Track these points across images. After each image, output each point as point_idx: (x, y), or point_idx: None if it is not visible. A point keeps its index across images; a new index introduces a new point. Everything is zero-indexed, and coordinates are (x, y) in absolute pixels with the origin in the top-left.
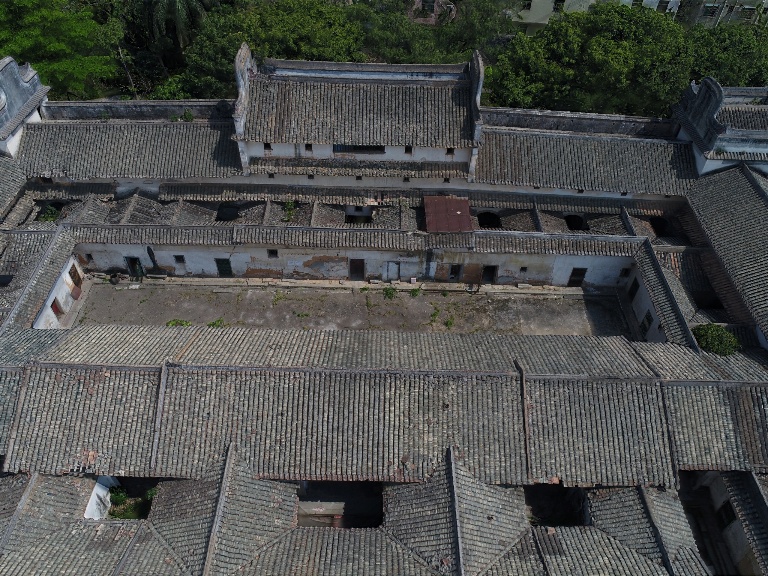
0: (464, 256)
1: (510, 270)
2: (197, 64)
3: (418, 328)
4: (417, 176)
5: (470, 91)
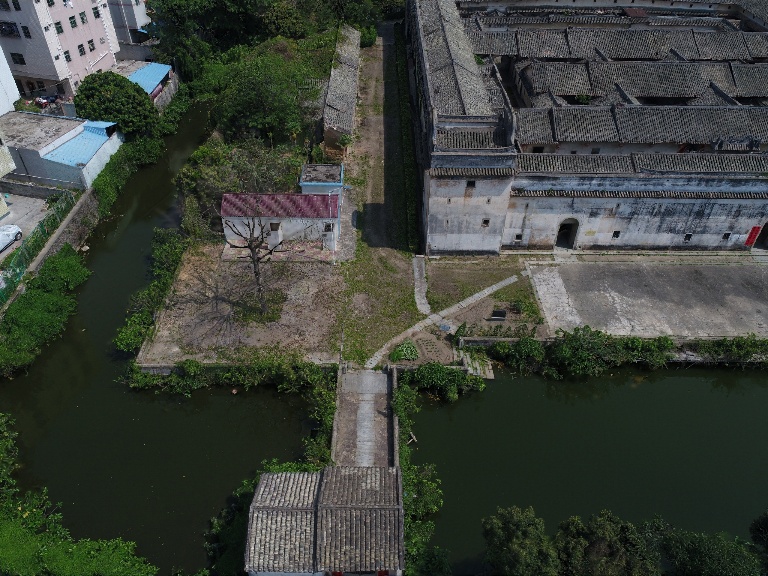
0: None
1: None
2: None
3: None
4: None
5: None
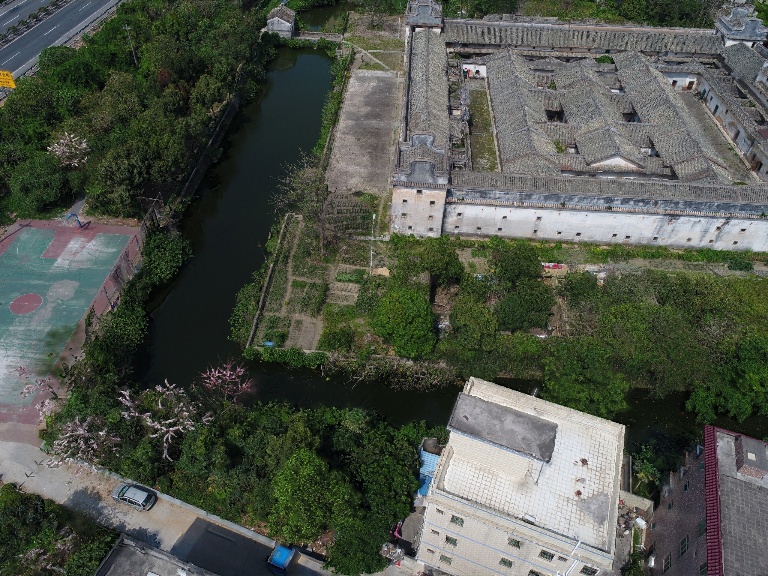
0: None
1: (764, 170)
2: None
3: None
4: None
5: None
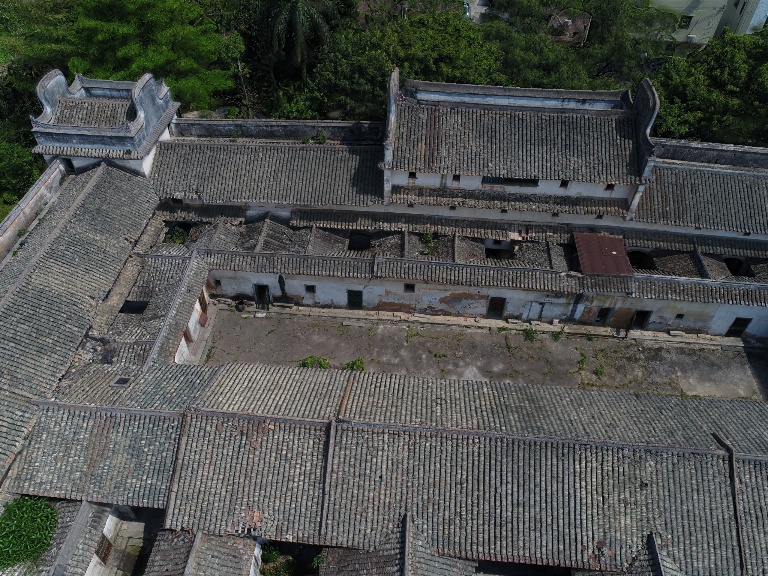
0: (617, 300)
1: (664, 316)
2: (331, 83)
3: (566, 376)
4: (572, 212)
5: (636, 122)
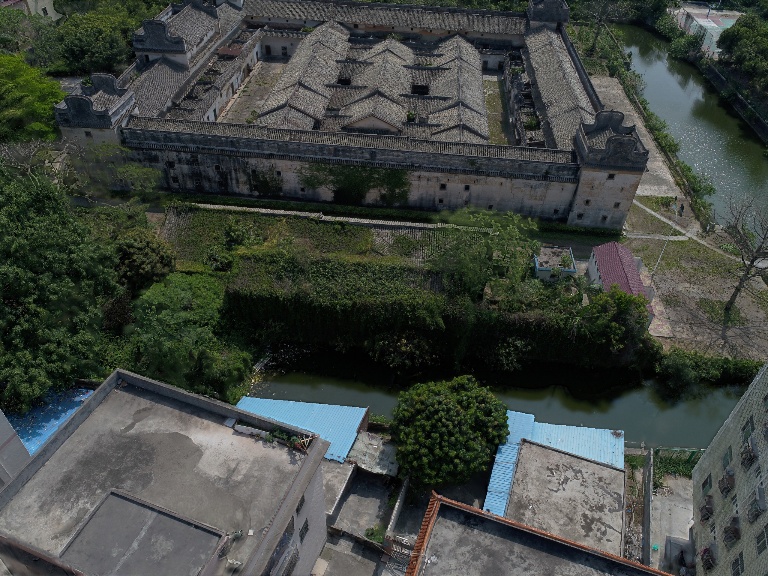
0: None
1: None
2: (107, 55)
3: (266, 88)
4: None
5: (195, 6)
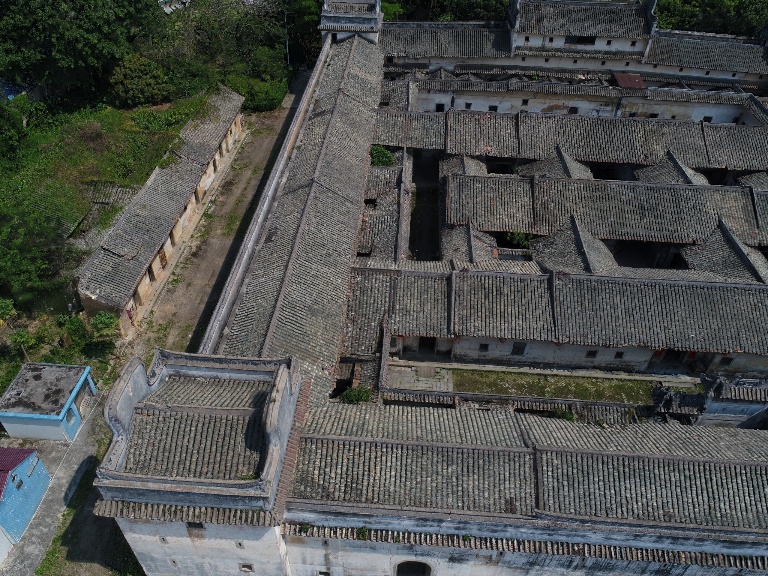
0: (639, 106)
1: None
2: (470, 2)
3: None
4: (613, 58)
5: (645, 10)
